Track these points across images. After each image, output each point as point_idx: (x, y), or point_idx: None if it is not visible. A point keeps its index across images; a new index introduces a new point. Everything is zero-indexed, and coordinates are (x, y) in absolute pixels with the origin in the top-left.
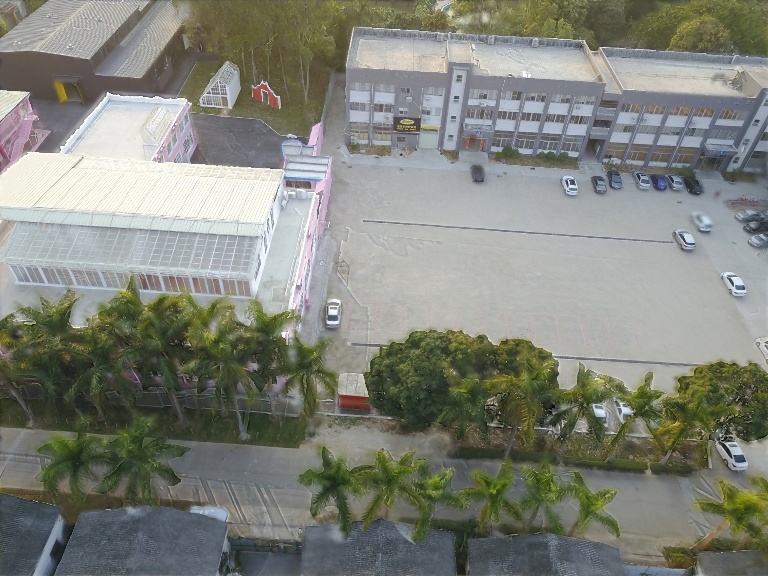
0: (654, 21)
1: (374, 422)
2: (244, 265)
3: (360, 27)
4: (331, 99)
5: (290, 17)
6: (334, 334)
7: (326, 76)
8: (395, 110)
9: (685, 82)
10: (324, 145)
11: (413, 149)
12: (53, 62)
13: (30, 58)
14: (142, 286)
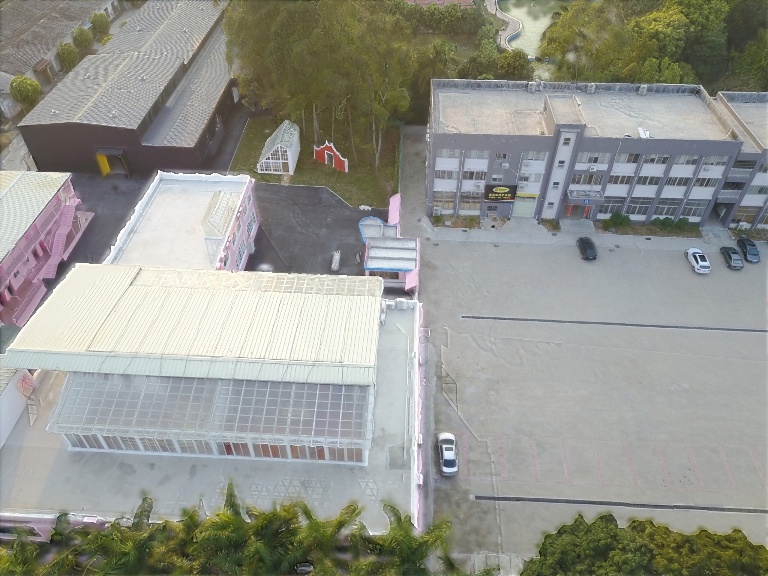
0: None
1: None
2: (356, 428)
3: (439, 79)
4: (402, 157)
5: (366, 76)
6: (452, 483)
7: (396, 132)
8: (487, 177)
9: None
10: (402, 217)
11: (505, 219)
12: (95, 133)
13: (70, 129)
14: (225, 452)
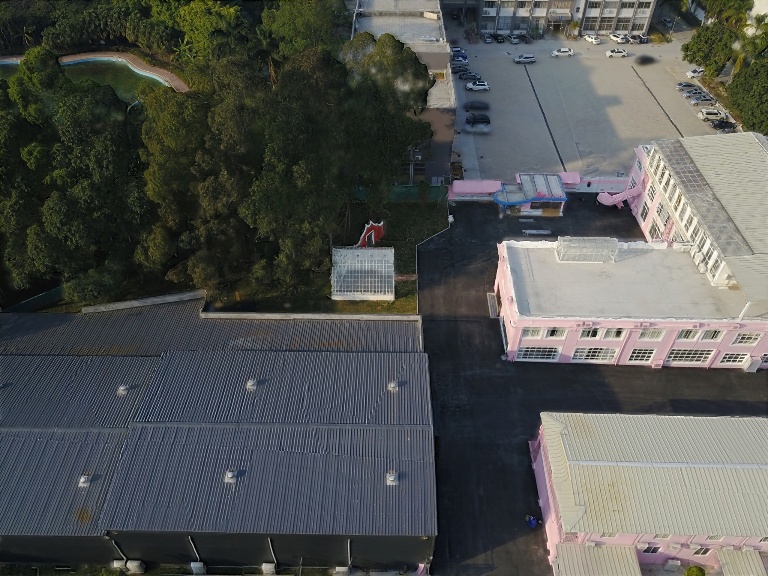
0: None
1: None
2: None
3: None
4: None
5: None
6: None
7: None
8: None
9: None
10: None
11: None
12: None
13: None
14: None
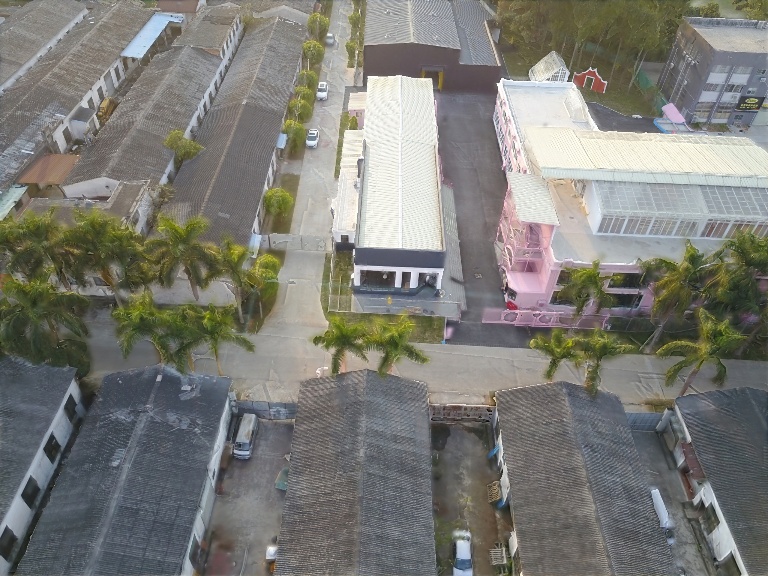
0: None
1: None
2: None
3: (688, 17)
4: None
5: (662, 7)
6: None
7: None
8: (744, 90)
9: None
10: None
11: (747, 126)
12: (425, 53)
13: (406, 49)
14: (706, 234)
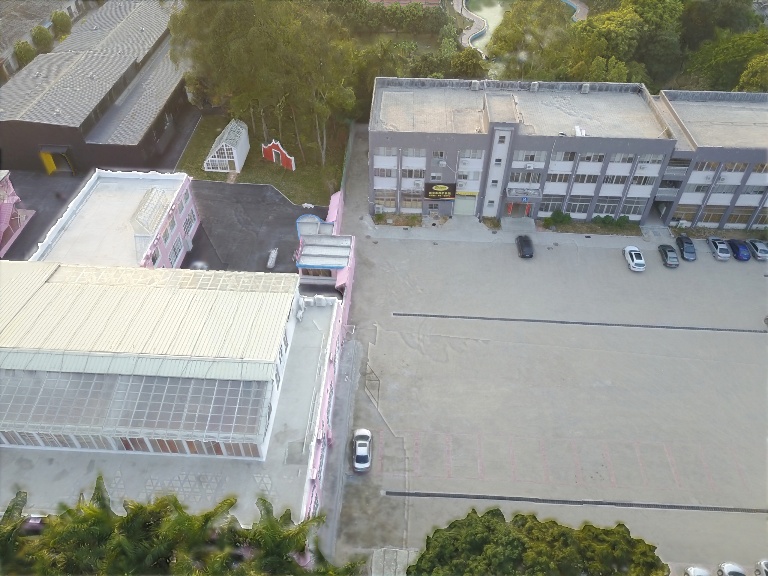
0: (718, 53)
1: None
2: (250, 423)
3: (383, 77)
4: (351, 155)
5: (303, 75)
6: (364, 479)
7: (345, 130)
8: (426, 175)
9: (767, 131)
10: (345, 215)
11: (447, 217)
12: (38, 131)
13: (13, 128)
14: (124, 447)
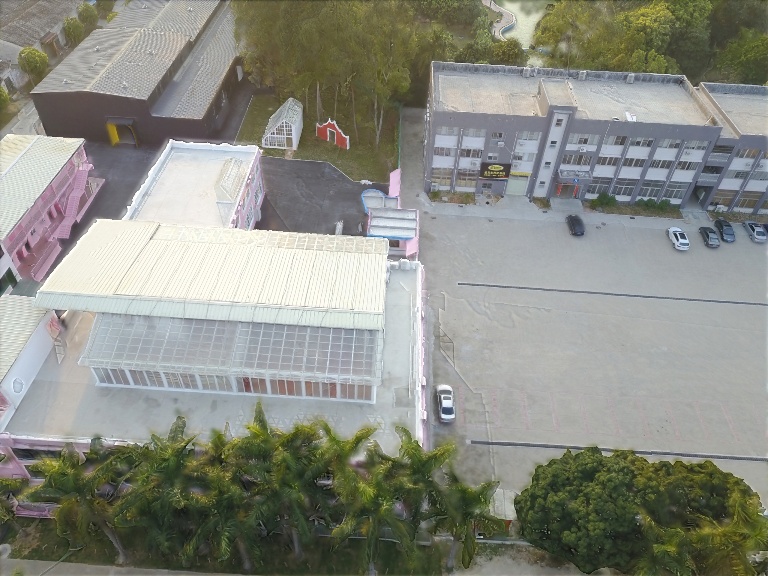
0: (748, 50)
1: (518, 550)
2: (367, 367)
3: (439, 62)
4: (401, 137)
5: (371, 55)
6: (450, 429)
7: (396, 112)
8: (483, 155)
9: None
10: (401, 192)
11: (499, 196)
12: (106, 103)
13: (81, 98)
14: (244, 389)
